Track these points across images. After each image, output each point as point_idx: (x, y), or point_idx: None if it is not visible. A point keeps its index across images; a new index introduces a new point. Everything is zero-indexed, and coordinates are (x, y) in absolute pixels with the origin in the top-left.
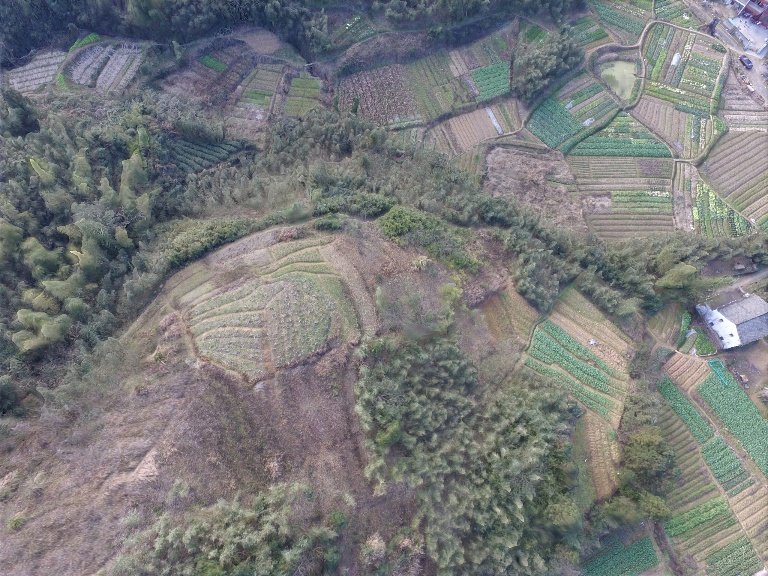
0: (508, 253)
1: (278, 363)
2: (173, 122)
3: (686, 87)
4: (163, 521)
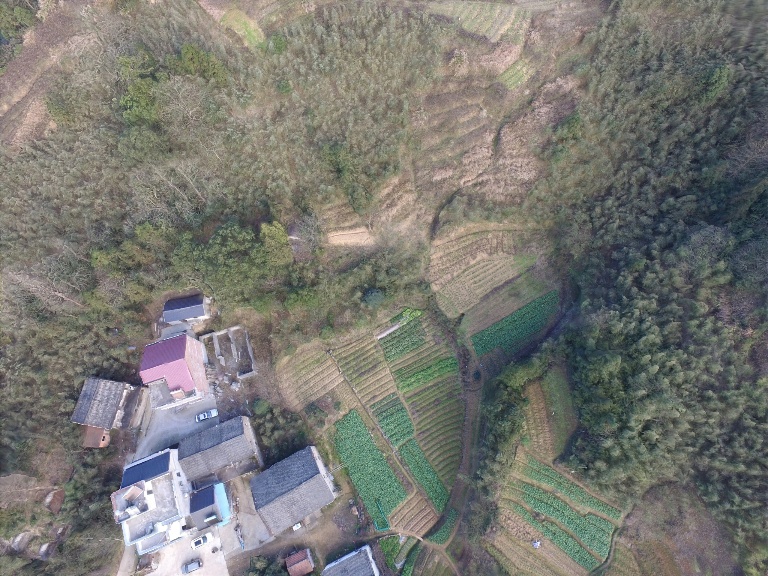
0: None
1: None
2: None
3: None
4: None
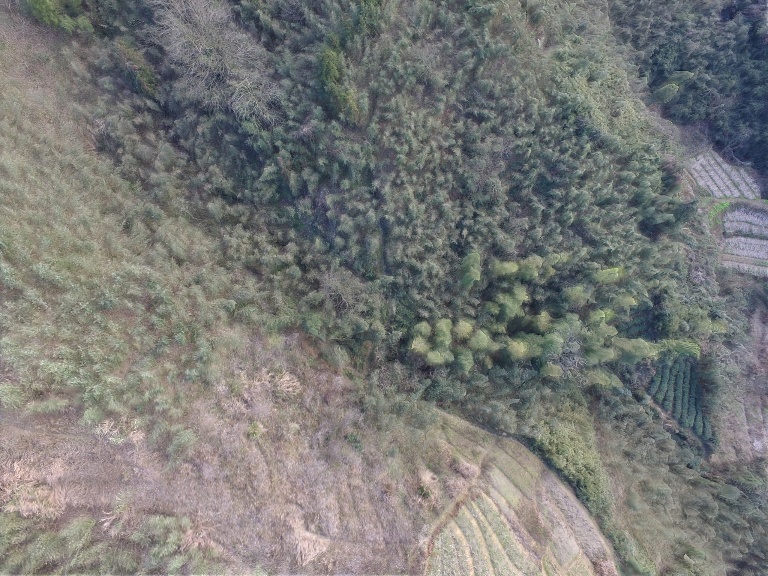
0: None
1: None
2: (712, 353)
3: None
4: None
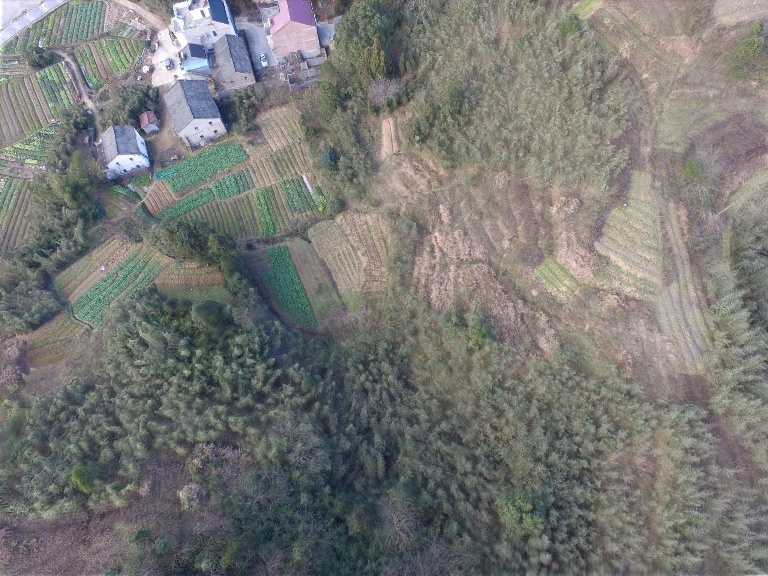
0: None
1: None
2: None
3: None
4: None
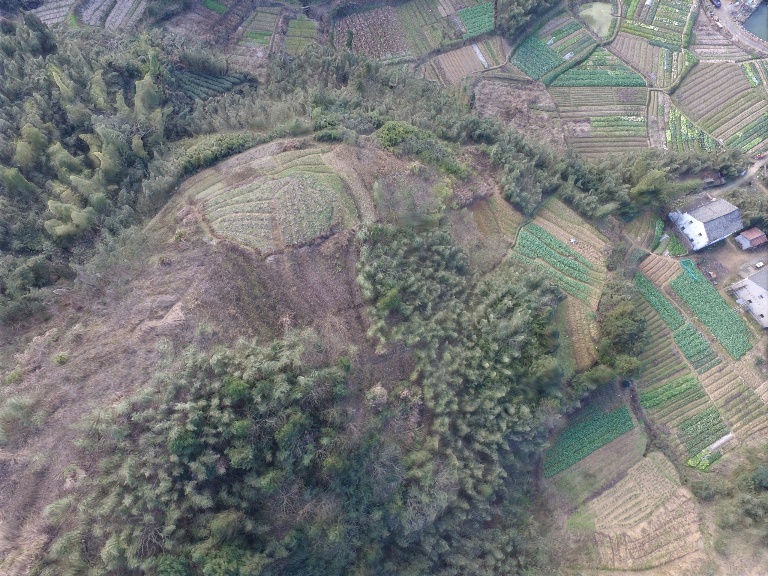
0: (494, 166)
1: (287, 242)
2: (180, 55)
3: (659, 24)
4: (191, 356)
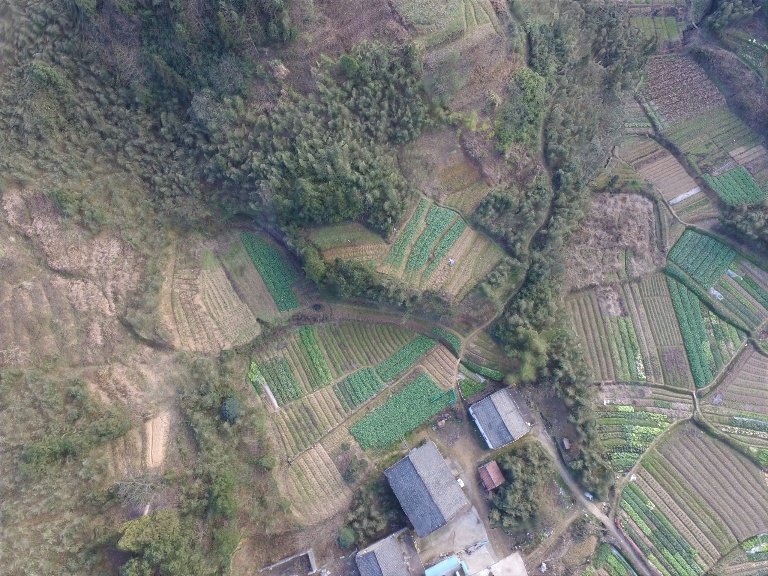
0: None
1: None
2: None
3: None
4: None
